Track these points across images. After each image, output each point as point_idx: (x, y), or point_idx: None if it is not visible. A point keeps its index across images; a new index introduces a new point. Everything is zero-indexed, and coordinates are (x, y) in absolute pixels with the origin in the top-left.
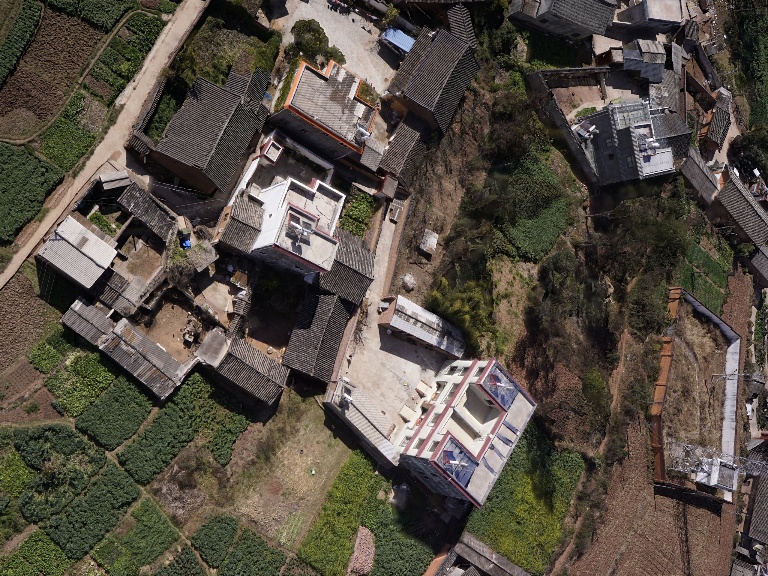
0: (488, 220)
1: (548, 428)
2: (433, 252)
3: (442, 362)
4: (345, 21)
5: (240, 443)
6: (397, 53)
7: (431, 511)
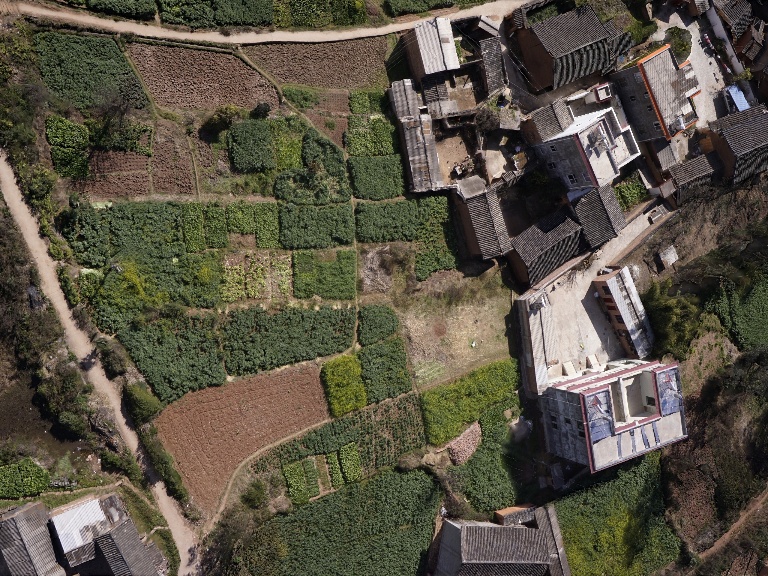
0: (734, 265)
1: (670, 489)
2: (667, 266)
3: (619, 356)
4: (704, 59)
5: (439, 275)
6: (728, 110)
7: (535, 465)
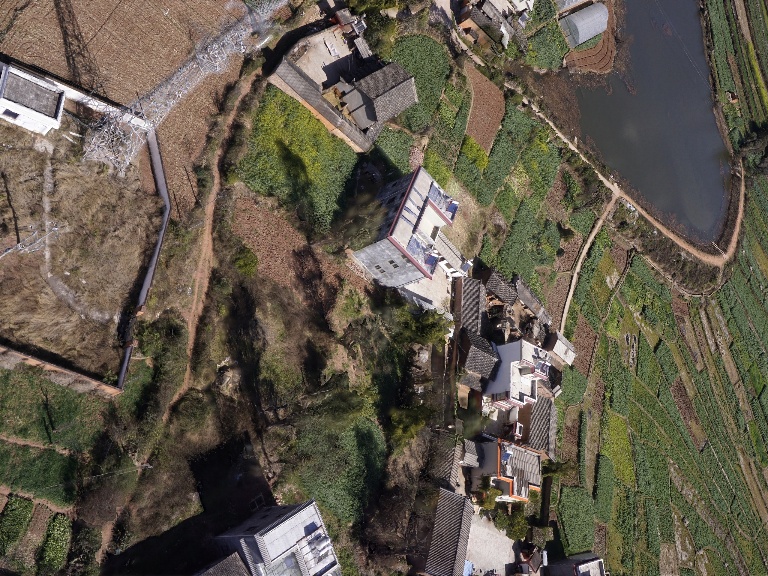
0: None
1: None
2: None
3: None
4: (485, 567)
5: None
6: None
7: None
